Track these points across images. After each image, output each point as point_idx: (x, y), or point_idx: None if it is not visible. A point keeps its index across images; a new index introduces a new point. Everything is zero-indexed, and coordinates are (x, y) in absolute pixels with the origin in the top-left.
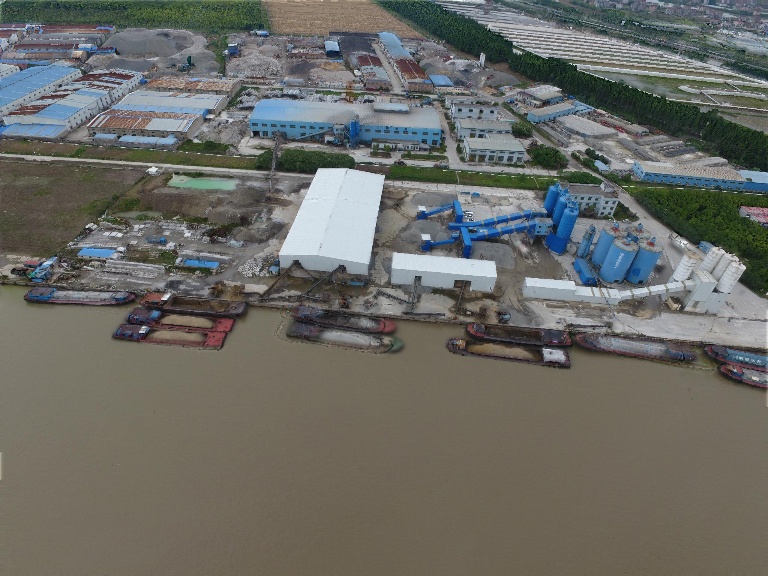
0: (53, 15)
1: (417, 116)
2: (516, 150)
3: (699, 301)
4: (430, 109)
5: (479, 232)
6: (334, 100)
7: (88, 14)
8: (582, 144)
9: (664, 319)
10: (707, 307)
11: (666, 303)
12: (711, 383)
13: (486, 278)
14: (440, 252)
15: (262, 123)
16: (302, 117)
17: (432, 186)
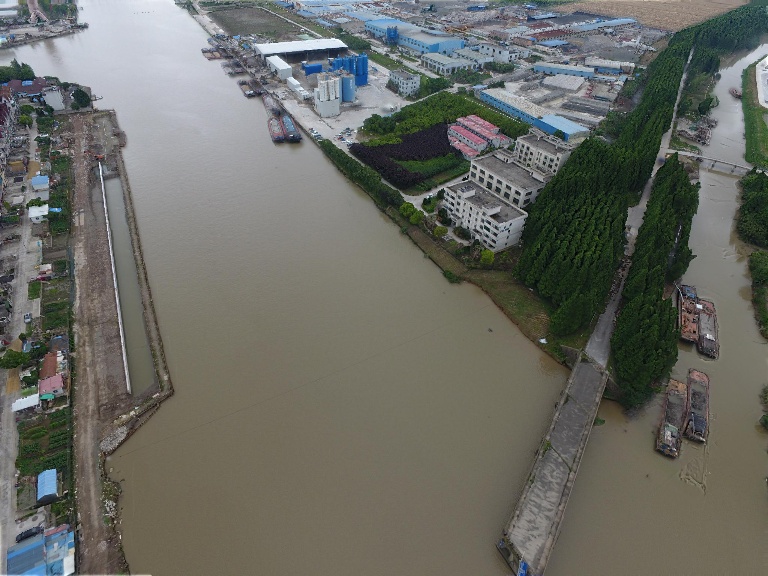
0: None
1: (435, 38)
2: (441, 62)
3: None
4: None
5: None
6: None
7: None
8: None
9: (303, 108)
10: None
11: None
12: None
13: None
14: None
15: (368, 26)
16: (385, 26)
17: (372, 63)
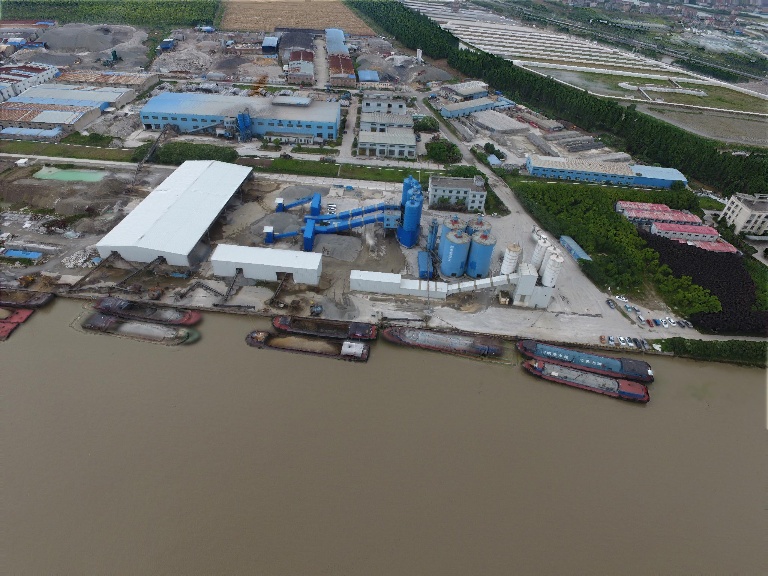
0: (2, 11)
1: (315, 109)
2: (406, 144)
3: (525, 295)
4: (334, 103)
5: (330, 225)
6: (248, 94)
7: (38, 10)
8: (487, 139)
9: (488, 313)
10: (535, 301)
11: (497, 297)
12: (508, 378)
13: (306, 270)
14: (284, 245)
15: (153, 116)
16: (195, 110)
17: (309, 179)
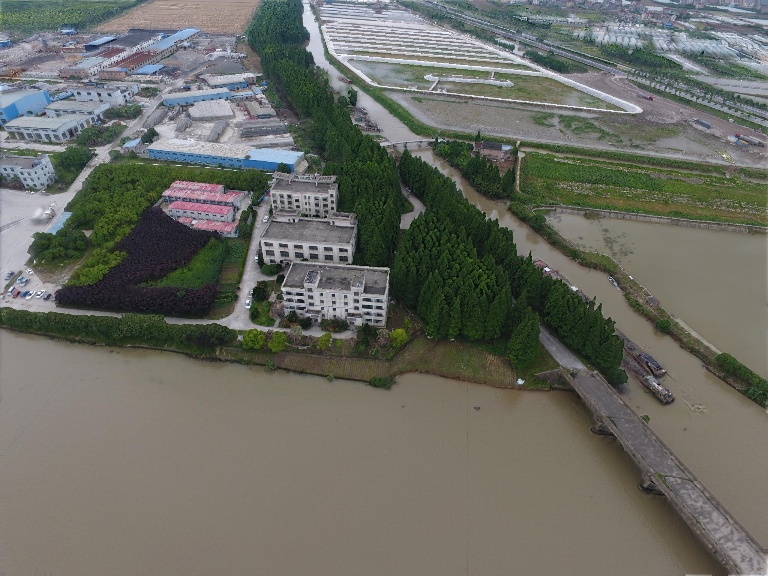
0: None
1: (0, 97)
2: (48, 127)
3: None
4: (37, 92)
5: None
6: None
7: None
8: (173, 125)
9: None
10: None
11: None
12: None
13: None
14: None
15: None
16: None
17: None
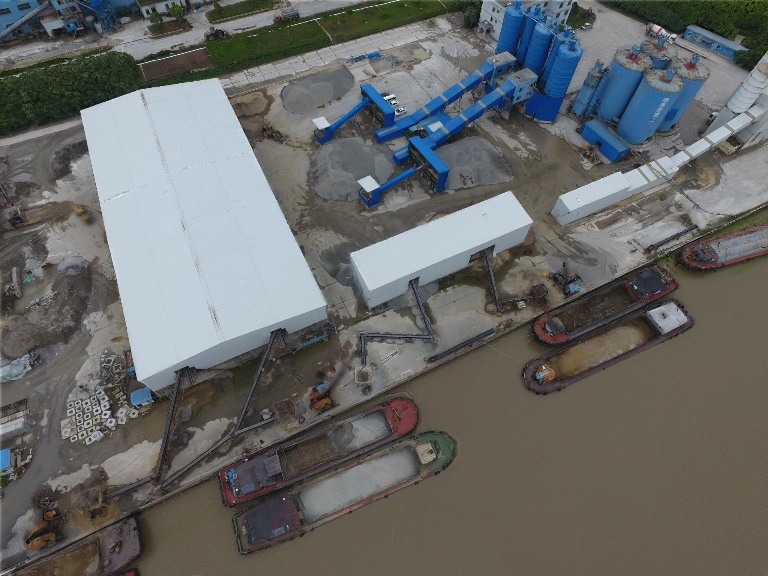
0: None
1: None
2: None
3: (762, 131)
4: None
5: (433, 133)
6: None
7: None
8: None
9: (731, 175)
10: (765, 134)
11: None
12: None
13: (517, 230)
14: (397, 197)
15: None
16: None
17: (297, 64)
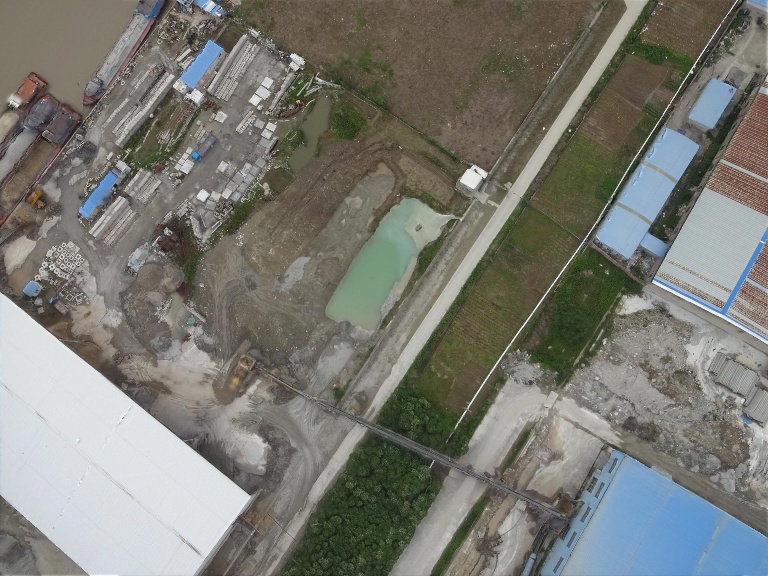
0: None
1: None
2: None
3: None
4: None
5: None
6: None
7: None
8: None
9: None
10: None
11: None
12: None
13: None
14: None
15: None
16: None
17: None
